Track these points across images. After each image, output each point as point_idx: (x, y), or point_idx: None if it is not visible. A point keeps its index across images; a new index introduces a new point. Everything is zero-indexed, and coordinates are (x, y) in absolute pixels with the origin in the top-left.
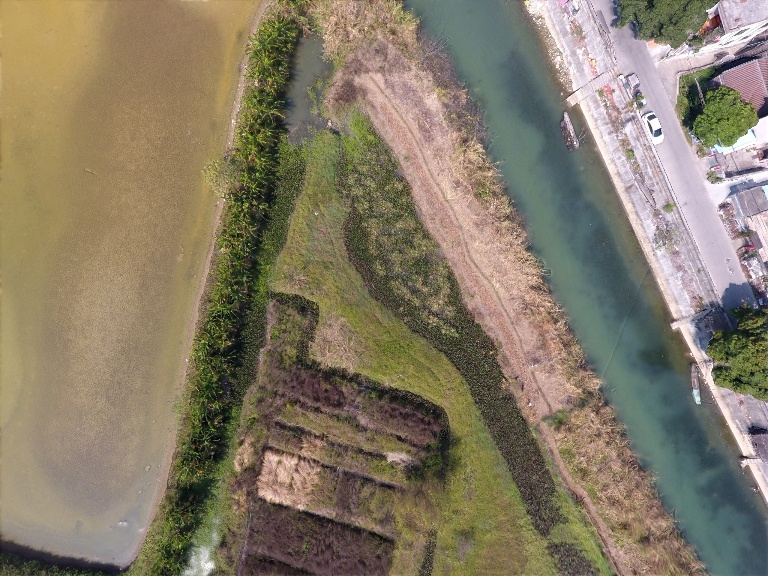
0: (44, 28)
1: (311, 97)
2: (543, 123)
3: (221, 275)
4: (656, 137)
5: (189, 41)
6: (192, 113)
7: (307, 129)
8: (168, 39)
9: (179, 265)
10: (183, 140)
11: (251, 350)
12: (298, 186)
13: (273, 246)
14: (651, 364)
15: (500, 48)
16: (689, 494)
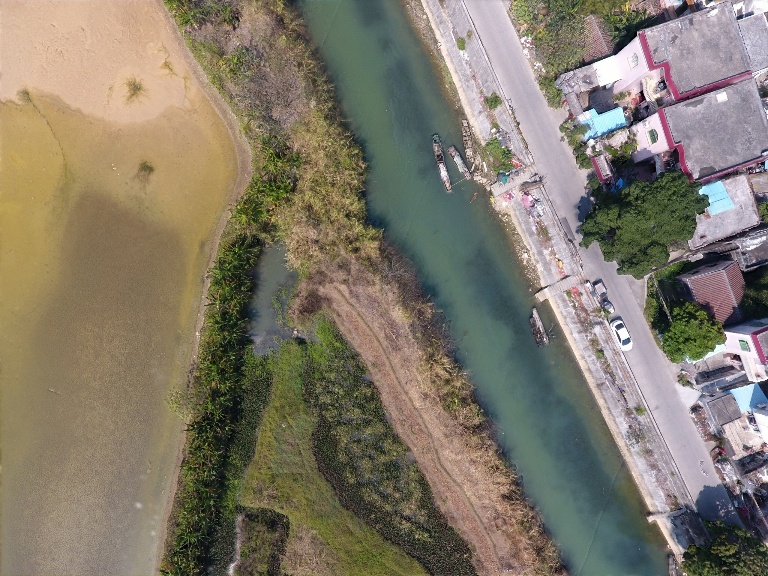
0: (4, 249)
1: (276, 307)
2: (512, 320)
3: None
4: (625, 345)
5: (151, 254)
6: (156, 327)
7: (273, 339)
8: (130, 253)
9: (147, 481)
10: (147, 355)
11: (221, 566)
12: (265, 398)
13: (241, 460)
14: (628, 557)
15: (466, 247)
16: None
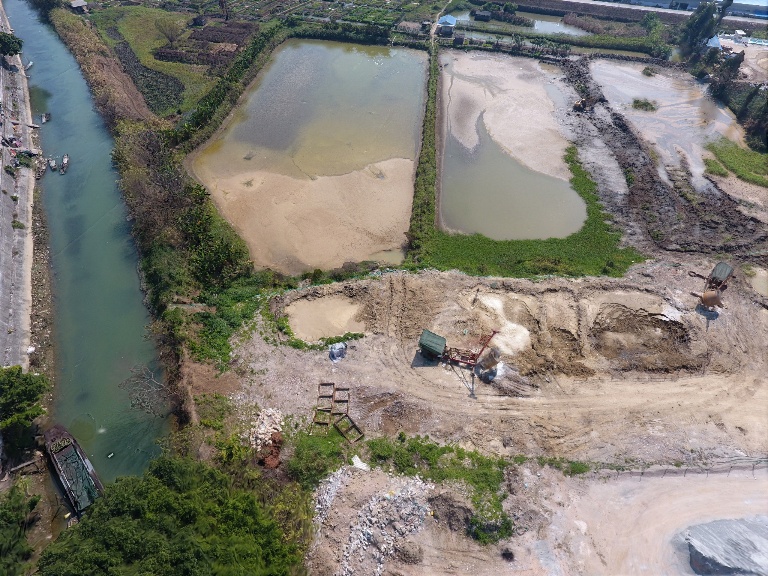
0: (326, 134)
1: None
2: None
3: None
4: None
5: None
6: None
7: None
8: None
9: (266, 85)
10: None
11: None
12: None
13: None
14: None
15: None
16: (53, 49)
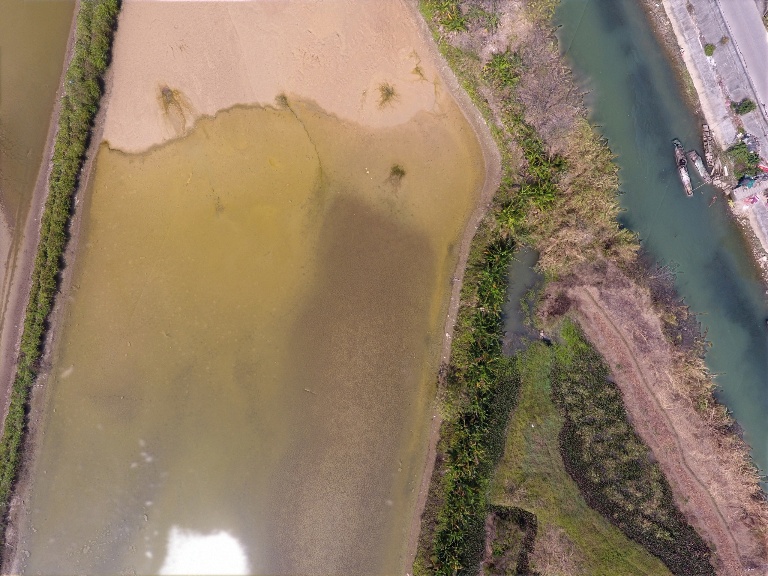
0: (262, 251)
1: (524, 309)
2: (749, 322)
3: (448, 497)
4: None
5: (402, 257)
6: (407, 328)
7: (521, 341)
8: (382, 256)
9: (397, 480)
10: (399, 355)
11: (472, 564)
12: (514, 399)
13: (492, 460)
14: None
15: (705, 250)
16: None
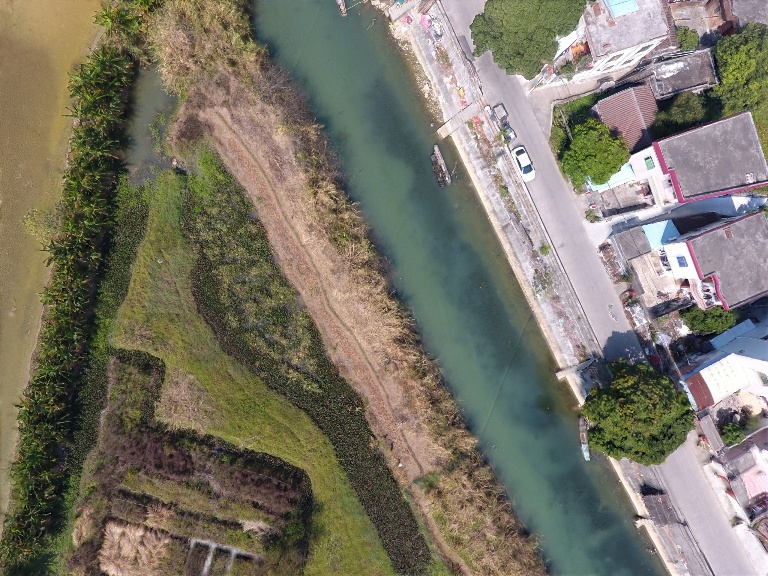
0: None
1: (153, 134)
2: (412, 157)
3: None
4: (526, 174)
5: (18, 75)
6: (23, 154)
7: (149, 169)
8: None
9: (11, 320)
10: (13, 184)
11: (90, 412)
12: (140, 232)
13: (113, 298)
14: (536, 417)
15: (363, 77)
16: (580, 557)
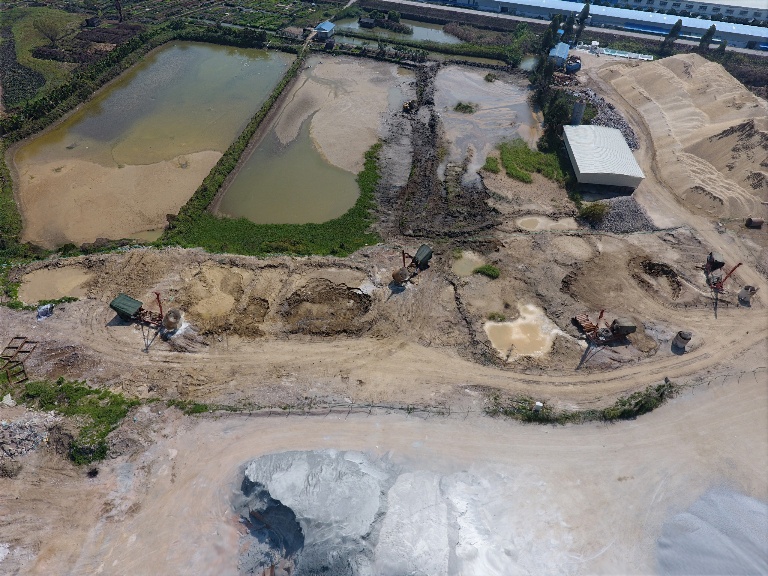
0: None
1: None
2: None
3: None
4: None
5: None
6: (97, 111)
7: None
8: None
9: None
10: (106, 105)
11: None
12: None
13: None
14: None
15: None
16: None
